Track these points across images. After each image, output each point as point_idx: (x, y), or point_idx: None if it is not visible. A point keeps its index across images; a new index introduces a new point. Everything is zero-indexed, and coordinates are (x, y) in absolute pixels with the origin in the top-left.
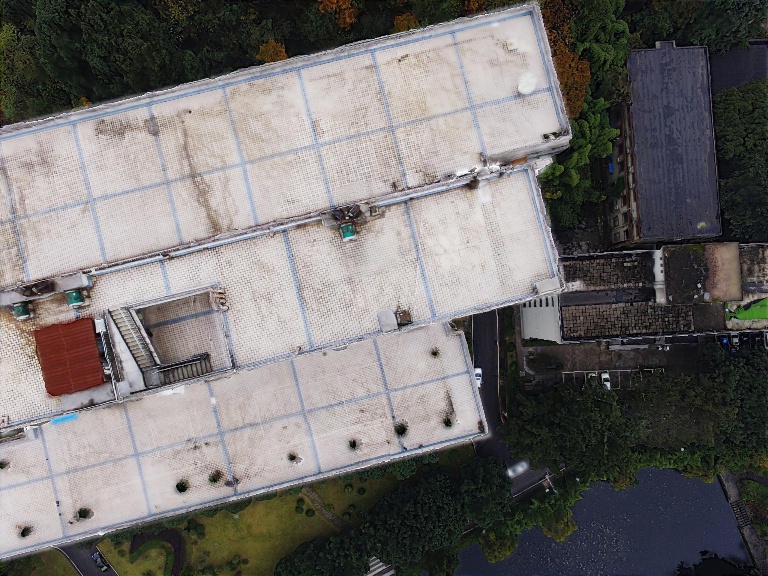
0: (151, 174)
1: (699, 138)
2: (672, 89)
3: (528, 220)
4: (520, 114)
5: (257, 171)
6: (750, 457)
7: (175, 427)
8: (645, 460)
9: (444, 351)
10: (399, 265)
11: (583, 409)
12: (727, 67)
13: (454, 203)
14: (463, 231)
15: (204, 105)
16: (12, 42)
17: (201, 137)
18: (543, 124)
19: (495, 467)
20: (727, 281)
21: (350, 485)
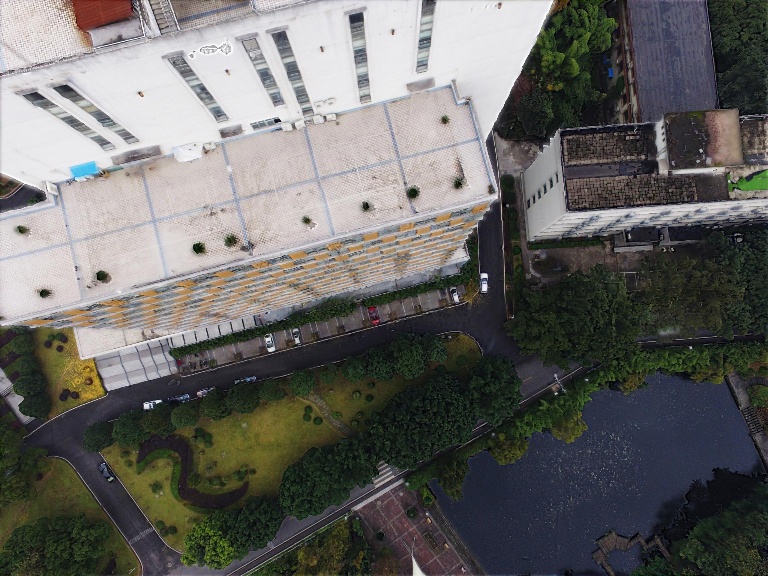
0: None
1: (695, 32)
2: None
3: None
4: None
5: None
6: (759, 354)
7: (192, 194)
8: (654, 359)
9: (454, 119)
10: None
11: (590, 290)
12: None
13: None
14: None
15: None
16: None
17: None
18: None
19: (503, 363)
20: (728, 146)
21: (358, 391)
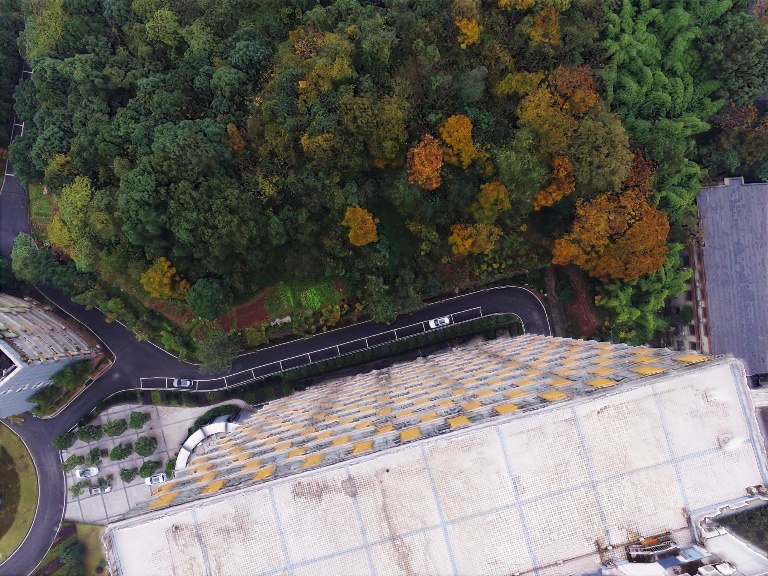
0: (349, 538)
1: None
2: (742, 226)
3: None
4: (722, 467)
5: (457, 532)
6: None
7: None
8: None
9: None
10: None
11: None
12: None
13: None
14: None
15: (402, 463)
16: (86, 197)
17: (399, 497)
18: (745, 477)
19: None
20: None
21: None
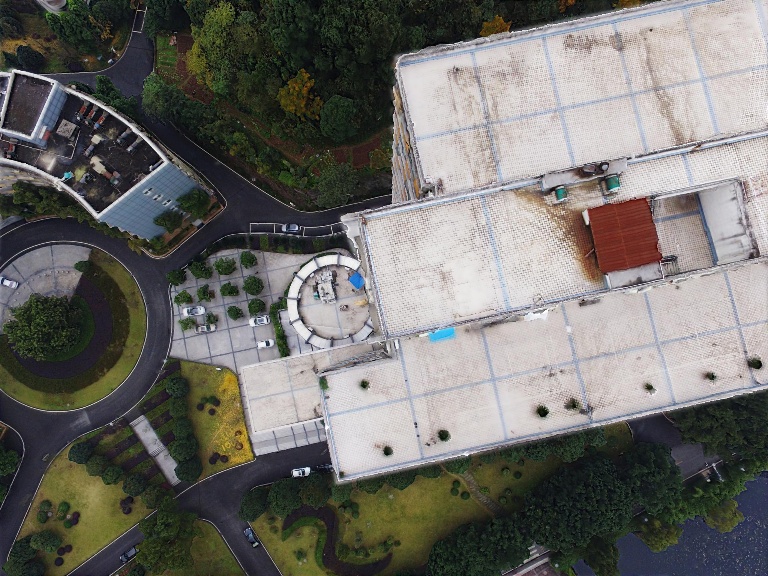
0: (616, 86)
1: None
2: None
3: None
4: None
5: (716, 86)
6: None
7: (531, 354)
8: None
9: None
10: None
11: None
12: None
13: None
14: None
15: (664, 24)
16: (231, 17)
17: (661, 54)
18: None
19: (666, 452)
20: None
21: (507, 468)
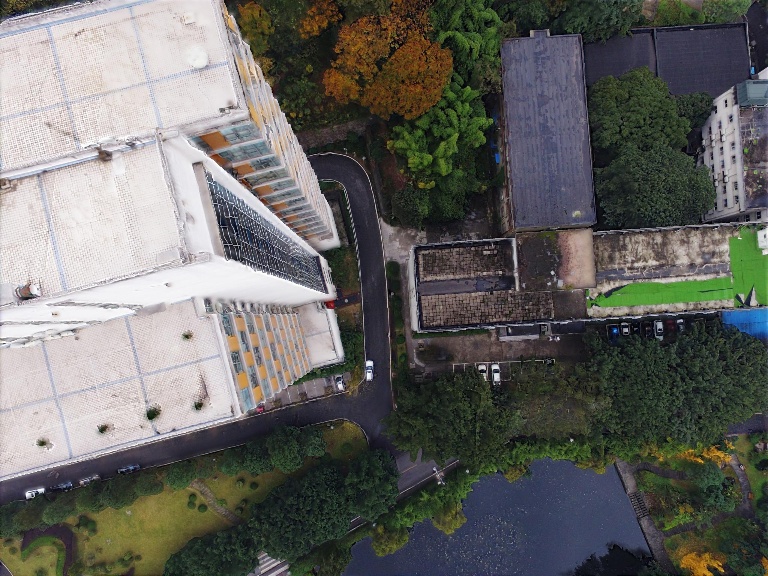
0: None
1: (574, 126)
2: (546, 78)
3: (161, 192)
4: (197, 88)
5: None
6: (639, 447)
7: None
8: (535, 451)
9: (197, 334)
10: (30, 239)
11: (454, 399)
12: (610, 56)
13: (87, 175)
14: (95, 204)
15: None
16: None
17: None
18: (220, 98)
19: (379, 460)
20: (581, 268)
21: (242, 480)
